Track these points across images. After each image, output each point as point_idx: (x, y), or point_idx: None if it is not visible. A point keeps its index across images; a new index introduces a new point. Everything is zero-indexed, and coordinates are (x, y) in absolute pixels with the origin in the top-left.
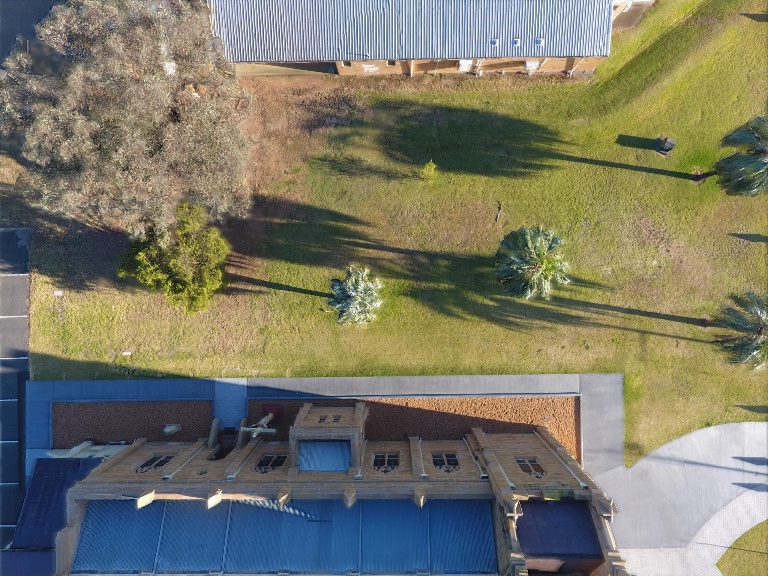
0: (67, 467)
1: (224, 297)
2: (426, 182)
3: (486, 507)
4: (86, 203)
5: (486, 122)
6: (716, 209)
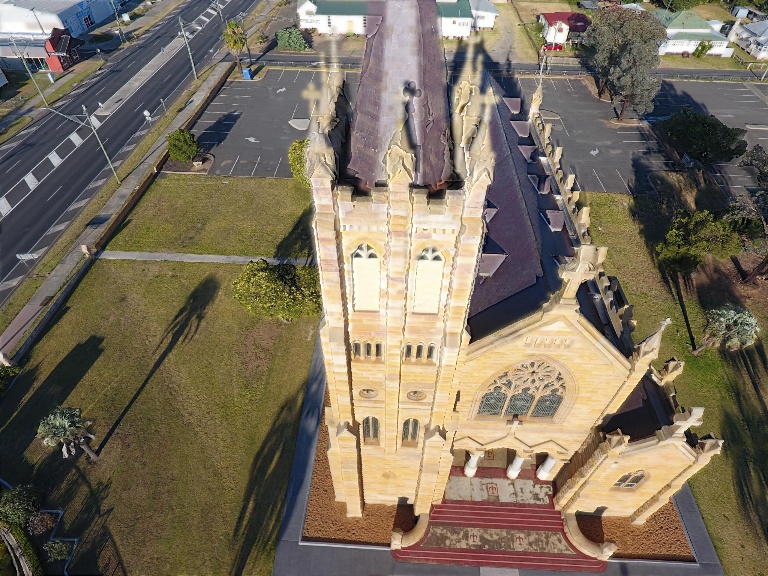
0: None
1: (660, 275)
2: None
3: None
4: None
5: None
6: None
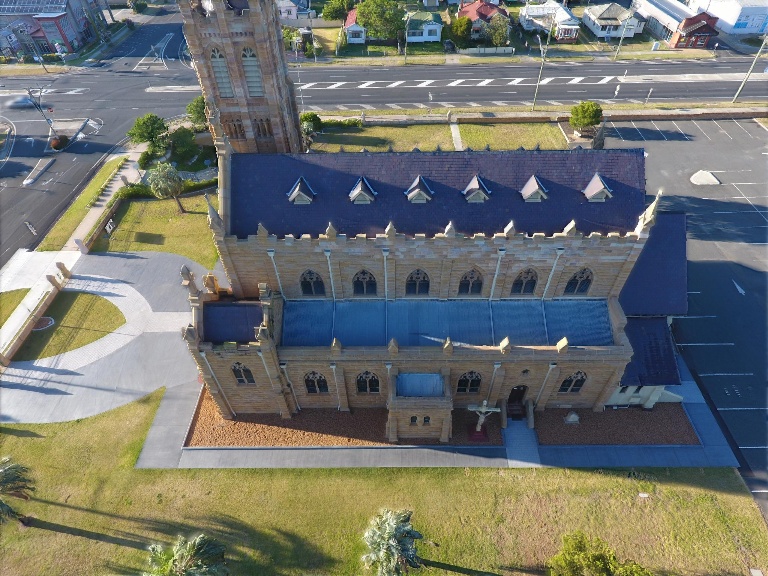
0: (650, 378)
1: None
2: None
3: (286, 344)
4: None
5: None
6: None
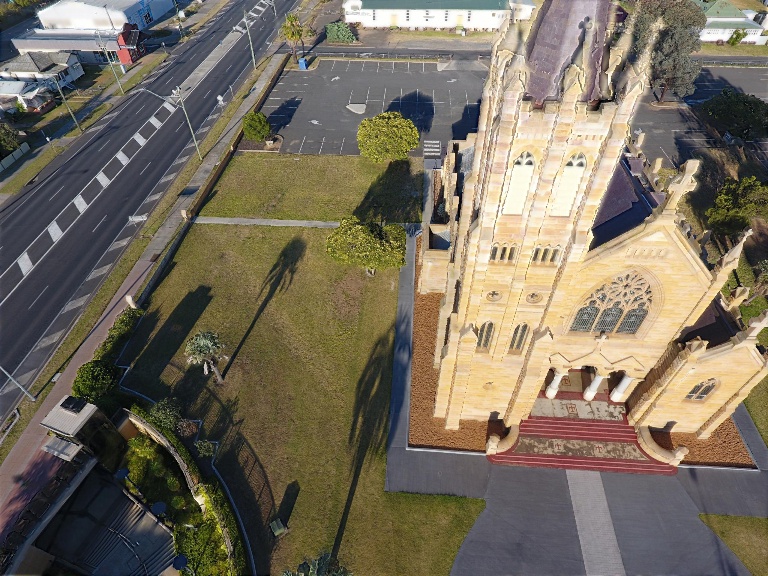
0: None
1: None
2: None
3: None
4: None
5: None
6: None
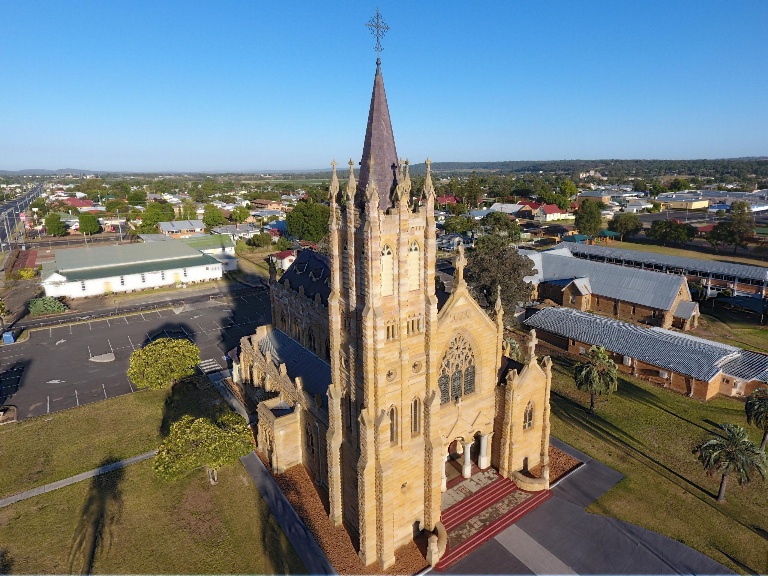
0: None
1: None
2: None
3: None
4: (473, 263)
5: (625, 383)
6: (767, 470)
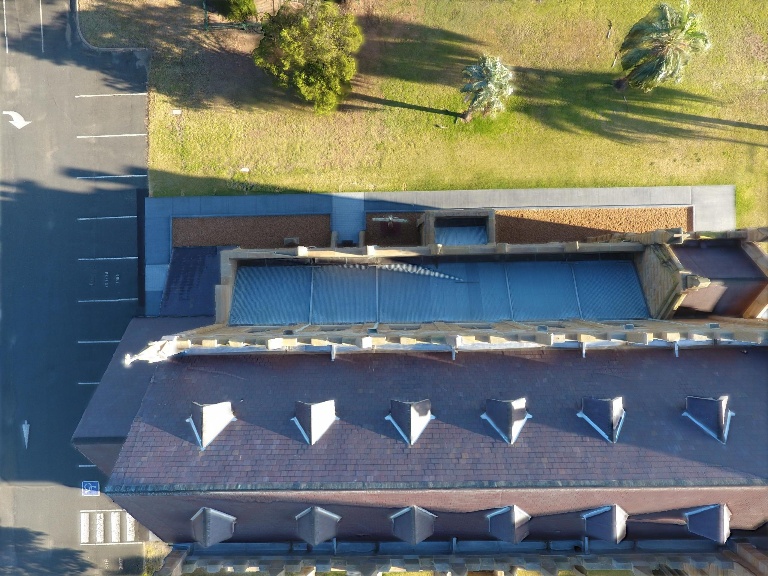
0: (204, 253)
1: (340, 114)
2: (537, 1)
3: (629, 269)
4: None
5: None
6: None
